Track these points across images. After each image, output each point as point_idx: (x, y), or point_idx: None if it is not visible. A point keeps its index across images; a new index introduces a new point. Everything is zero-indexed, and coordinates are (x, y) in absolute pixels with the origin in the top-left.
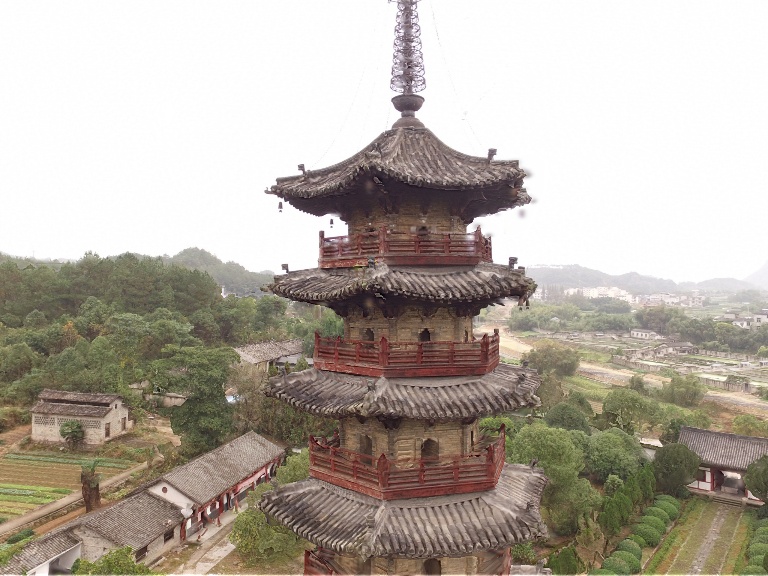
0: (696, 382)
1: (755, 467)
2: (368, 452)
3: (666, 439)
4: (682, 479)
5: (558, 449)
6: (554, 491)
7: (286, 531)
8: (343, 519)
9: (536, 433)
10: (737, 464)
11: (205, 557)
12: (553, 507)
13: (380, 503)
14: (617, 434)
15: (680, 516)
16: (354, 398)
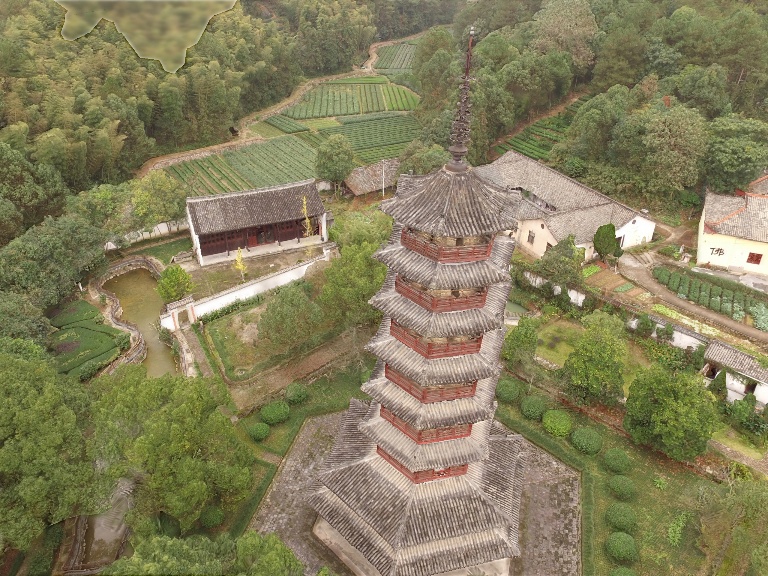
0: None
1: None
2: None
3: None
4: None
5: None
6: None
7: None
8: None
9: None
10: None
11: None
12: None
13: None
14: None
15: None
16: None
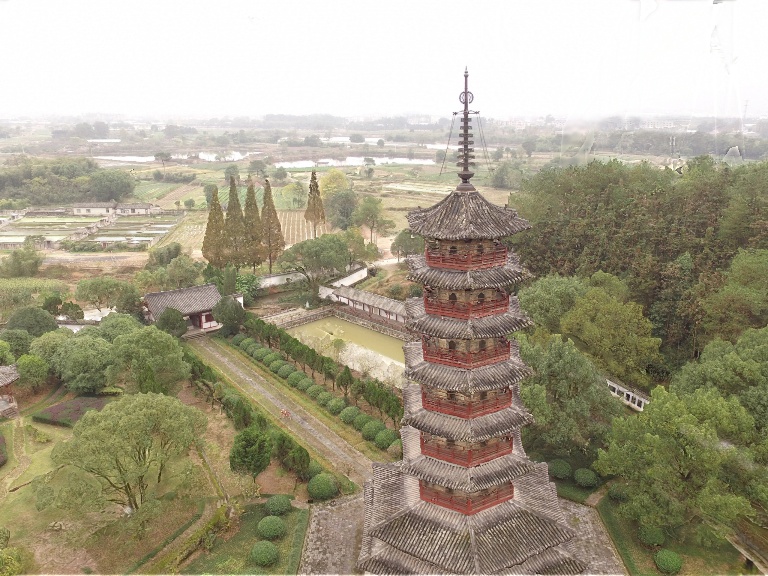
0: (34, 251)
1: (225, 306)
2: (484, 347)
3: (122, 309)
4: (183, 332)
5: (167, 342)
6: (160, 376)
7: (4, 544)
8: (500, 374)
9: (138, 337)
10: (197, 309)
11: None
12: (169, 387)
13: (510, 360)
14: (120, 317)
15: (196, 357)
16: (509, 323)
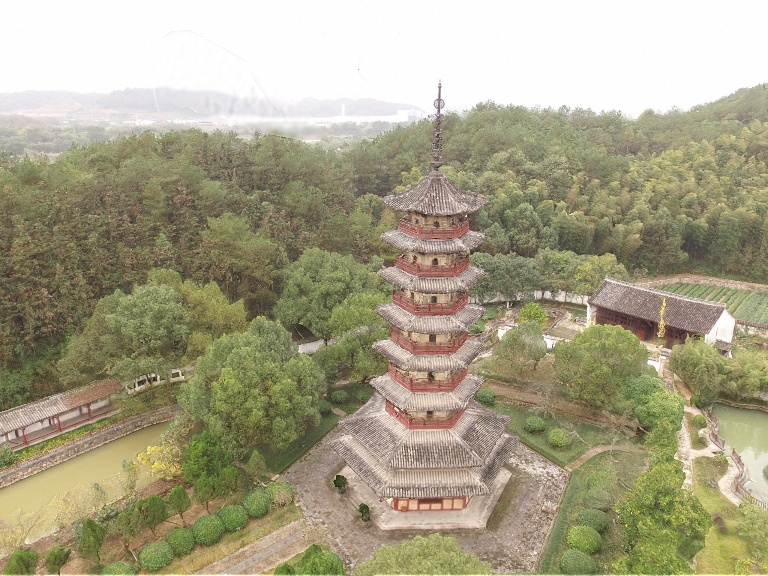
0: None
1: None
2: None
3: None
4: None
5: None
6: None
7: None
8: None
9: None
10: None
11: None
12: None
13: None
14: None
15: None
16: None
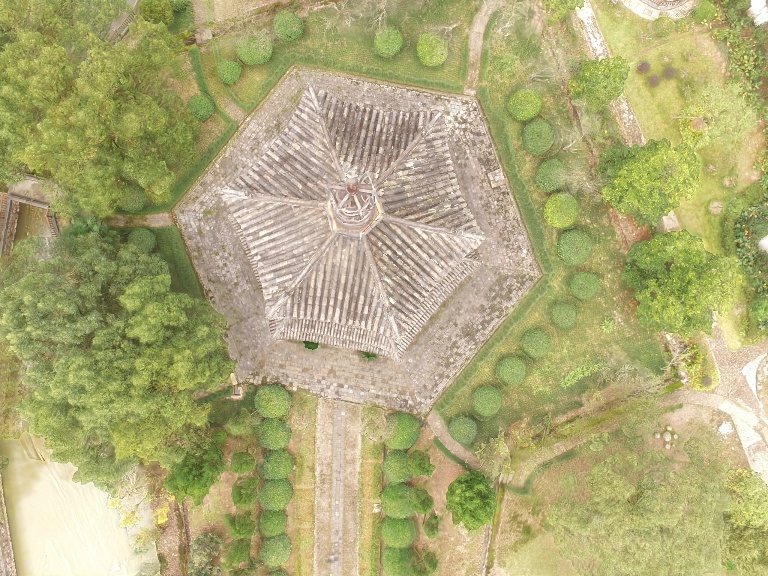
0: None
1: None
2: None
3: None
4: None
5: None
6: None
7: None
8: None
9: None
10: None
11: (766, 450)
12: None
13: None
14: None
15: None
16: None
